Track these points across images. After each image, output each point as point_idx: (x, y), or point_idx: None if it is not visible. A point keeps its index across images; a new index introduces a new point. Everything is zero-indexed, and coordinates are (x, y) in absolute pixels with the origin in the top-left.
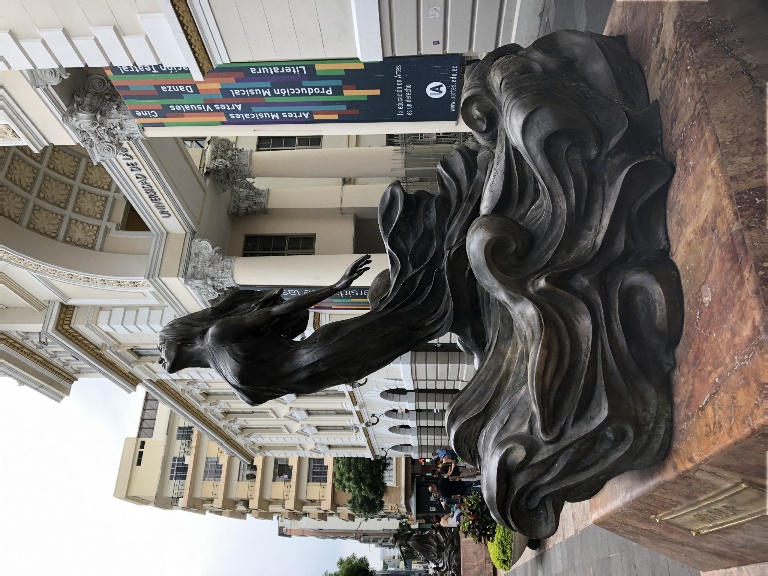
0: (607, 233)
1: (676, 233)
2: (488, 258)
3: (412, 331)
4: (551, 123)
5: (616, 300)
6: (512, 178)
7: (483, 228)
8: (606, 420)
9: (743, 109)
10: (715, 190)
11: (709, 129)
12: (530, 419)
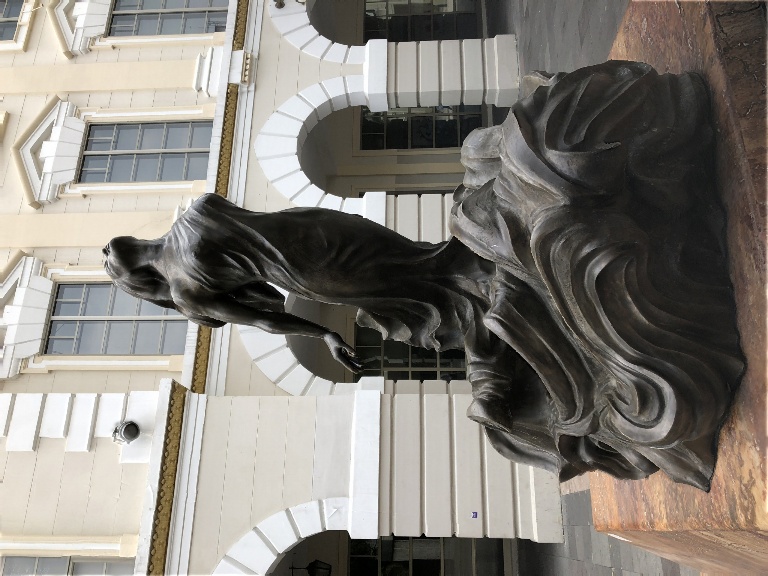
0: None
1: None
2: None
3: None
4: None
5: None
6: None
7: None
8: None
9: None
10: None
11: None
12: None
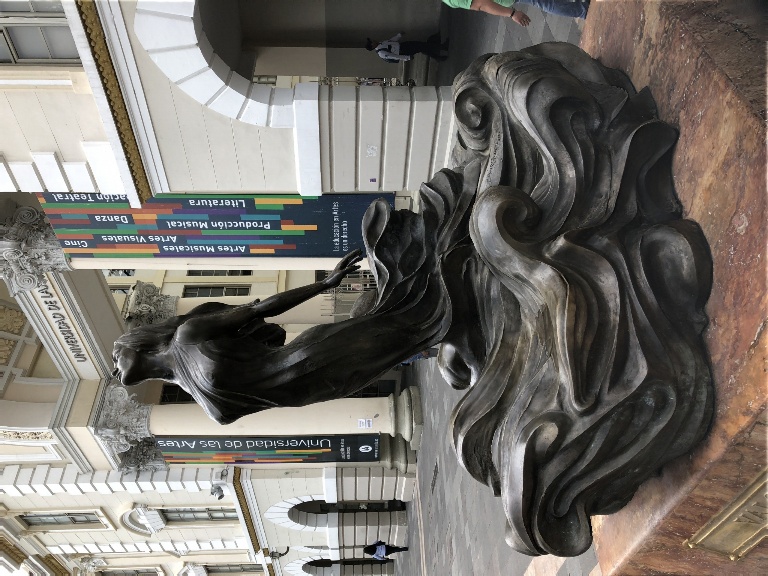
0: (619, 196)
1: (689, 190)
2: (500, 224)
3: (407, 334)
4: (556, 91)
5: (639, 256)
6: (510, 166)
7: (492, 195)
8: (646, 380)
9: (745, 54)
10: (736, 117)
11: (717, 71)
12: (558, 393)
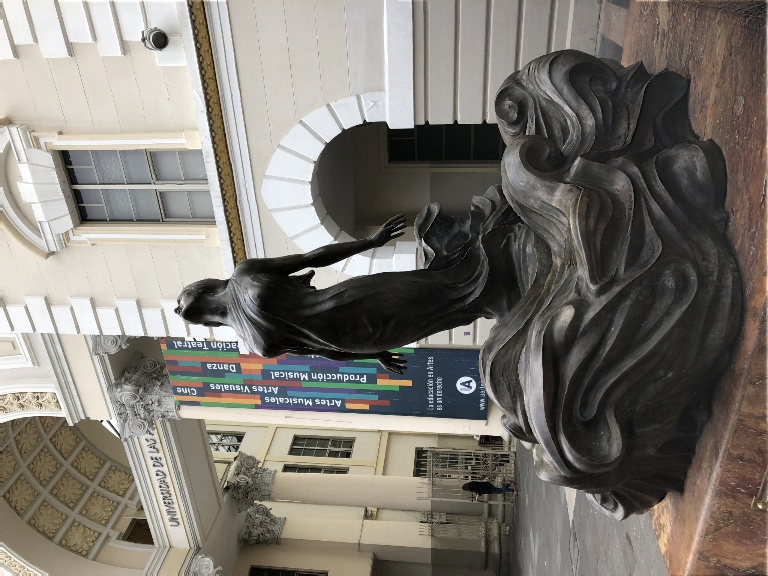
0: (636, 132)
1: (702, 118)
2: (523, 158)
3: (445, 288)
4: (574, 60)
5: (654, 168)
6: None
7: (517, 139)
8: (662, 256)
9: None
10: (724, 27)
11: (709, 9)
12: (577, 284)
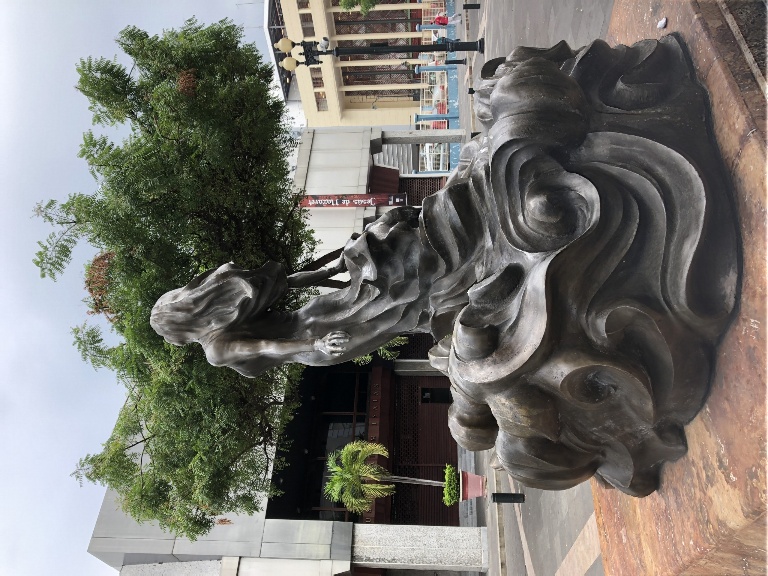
0: None
1: None
2: None
3: None
4: None
5: None
6: None
7: None
8: None
9: None
10: (651, 575)
11: None
12: None
